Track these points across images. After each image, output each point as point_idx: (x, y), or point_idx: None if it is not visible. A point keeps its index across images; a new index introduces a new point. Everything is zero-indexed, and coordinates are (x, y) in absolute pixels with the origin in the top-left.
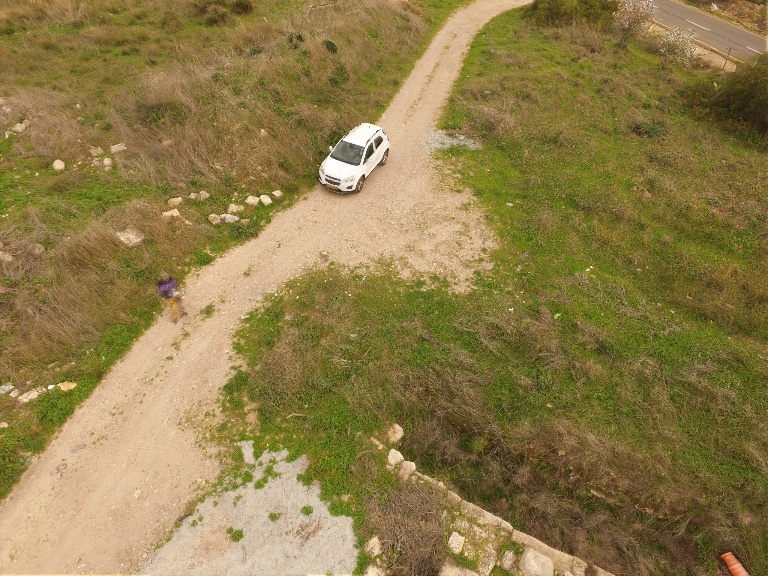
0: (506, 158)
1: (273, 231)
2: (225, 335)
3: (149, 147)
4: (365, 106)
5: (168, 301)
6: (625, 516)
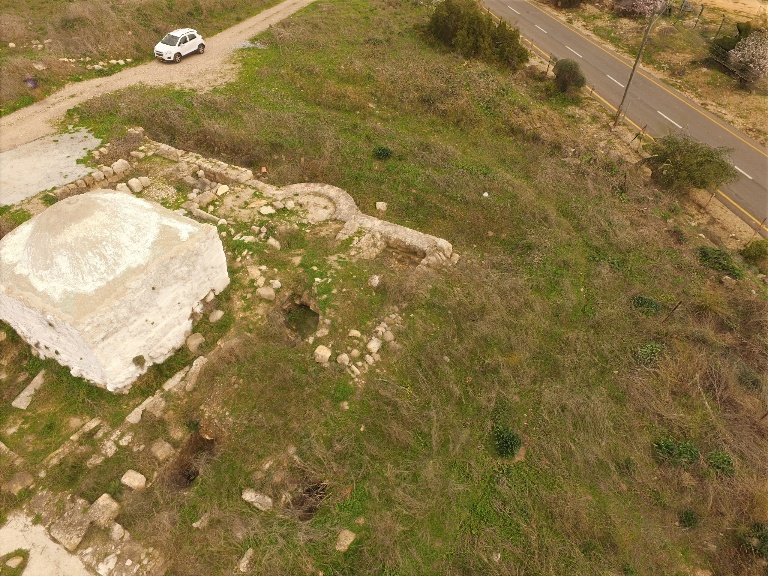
0: (275, 52)
1: (120, 74)
2: (77, 102)
3: (64, 40)
4: (209, 29)
5: (54, 92)
6: (228, 157)
